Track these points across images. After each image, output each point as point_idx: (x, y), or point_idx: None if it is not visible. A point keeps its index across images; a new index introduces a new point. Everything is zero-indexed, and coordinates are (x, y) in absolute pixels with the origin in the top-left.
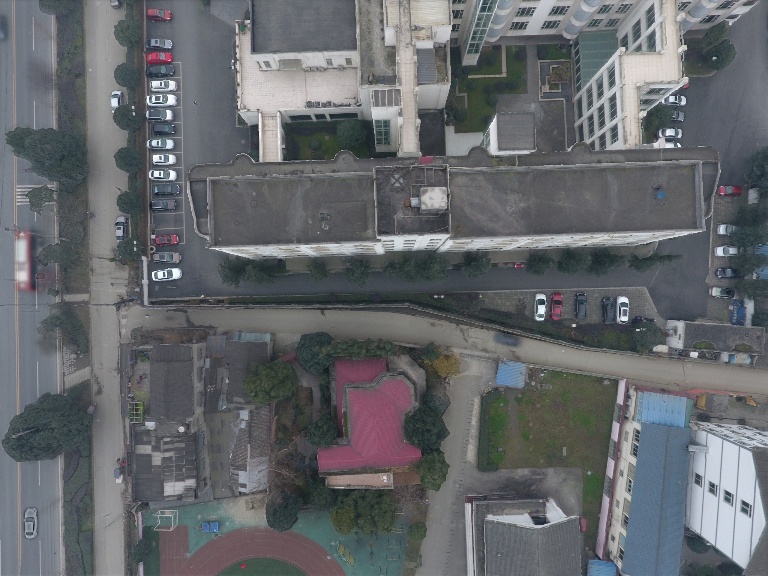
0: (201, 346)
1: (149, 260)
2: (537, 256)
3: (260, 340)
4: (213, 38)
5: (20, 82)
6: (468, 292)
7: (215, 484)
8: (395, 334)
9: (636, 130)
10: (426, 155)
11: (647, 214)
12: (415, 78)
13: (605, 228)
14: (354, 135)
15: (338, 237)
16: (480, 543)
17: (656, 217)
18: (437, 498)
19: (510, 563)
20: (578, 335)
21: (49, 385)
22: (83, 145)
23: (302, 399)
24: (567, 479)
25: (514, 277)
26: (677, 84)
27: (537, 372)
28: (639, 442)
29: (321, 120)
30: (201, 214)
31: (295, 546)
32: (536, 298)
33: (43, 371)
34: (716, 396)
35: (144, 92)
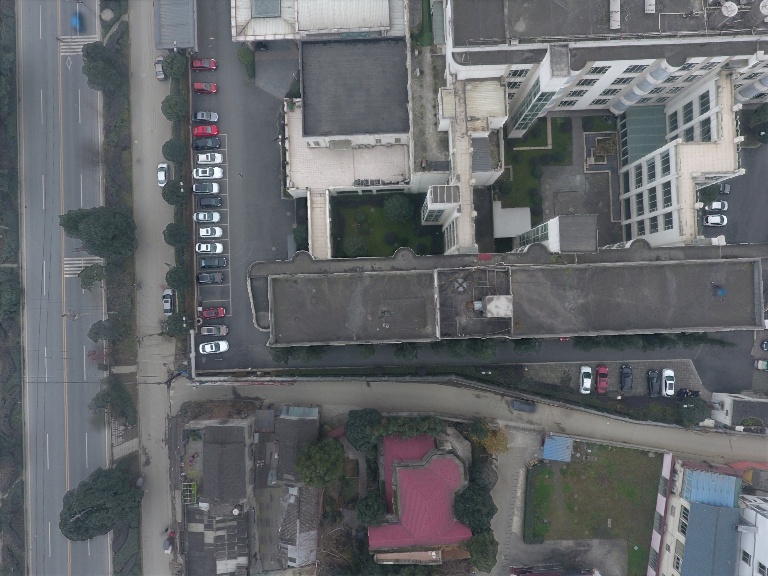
0: (251, 422)
1: (196, 332)
2: None
3: (308, 414)
4: (258, 110)
5: (67, 155)
6: (513, 364)
7: (264, 557)
8: (440, 406)
9: (691, 220)
10: None
11: (706, 310)
12: (471, 169)
13: (664, 324)
14: (402, 213)
15: (397, 333)
16: None
17: (715, 313)
18: None
19: None
20: (623, 408)
21: (98, 456)
22: (132, 222)
23: (348, 470)
24: (612, 551)
25: (559, 349)
26: (733, 174)
27: (582, 444)
28: (688, 521)
29: (367, 193)
30: (260, 308)
31: None
32: (582, 371)
33: (92, 442)
34: (763, 472)
35: (190, 165)
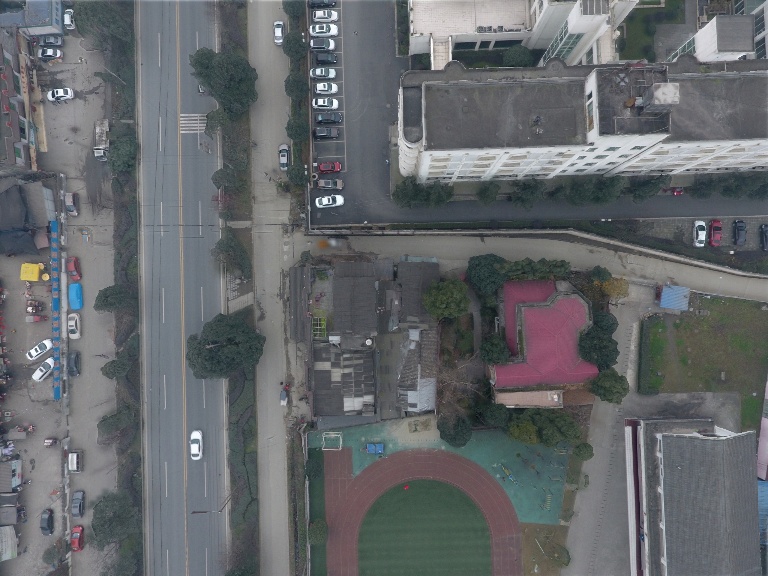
0: None
1: (311, 187)
2: (705, 179)
3: None
4: None
5: (183, 13)
6: (627, 219)
7: (382, 405)
8: None
9: None
10: None
11: None
12: None
13: None
14: (525, 60)
15: (548, 142)
16: (649, 461)
17: None
18: (597, 422)
19: (691, 475)
20: (737, 262)
21: (213, 310)
22: (254, 71)
23: (463, 324)
24: (725, 404)
25: (672, 205)
26: None
27: (695, 298)
28: None
29: (482, 49)
30: (407, 122)
31: (458, 468)
32: (696, 225)
33: (207, 296)
34: None
35: (306, 22)
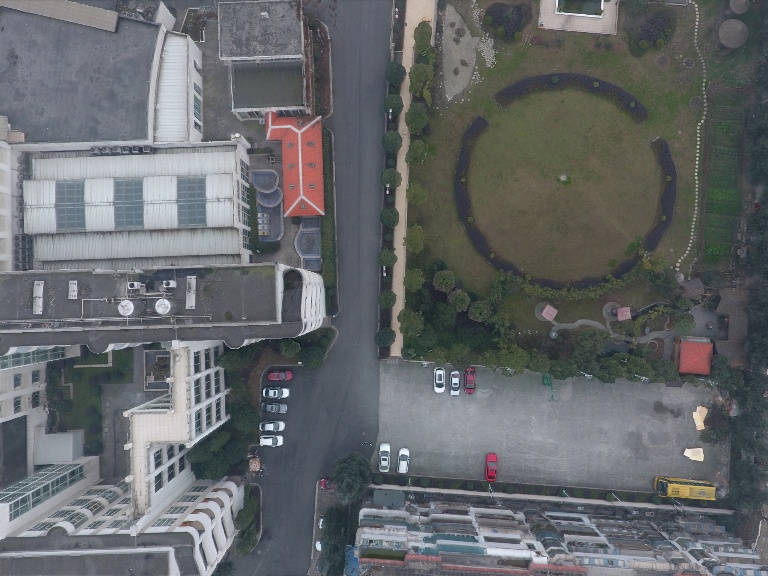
0: None
1: None
2: None
3: None
4: None
5: None
6: None
7: None
8: None
9: None
10: (9, 461)
11: None
12: None
13: None
14: None
15: None
16: None
17: None
18: None
19: None
20: None
21: None
22: None
23: None
24: None
25: None
26: None
27: None
28: None
29: None
30: None
31: None
32: None
33: None
34: None
35: None
